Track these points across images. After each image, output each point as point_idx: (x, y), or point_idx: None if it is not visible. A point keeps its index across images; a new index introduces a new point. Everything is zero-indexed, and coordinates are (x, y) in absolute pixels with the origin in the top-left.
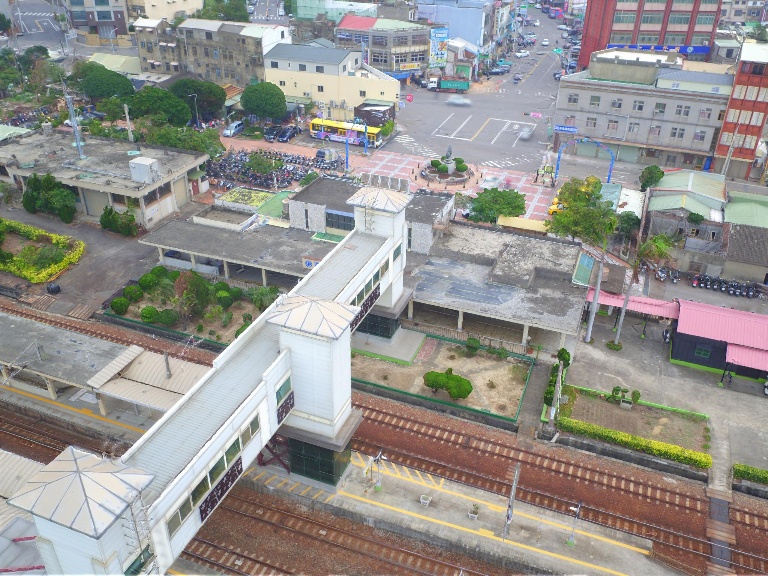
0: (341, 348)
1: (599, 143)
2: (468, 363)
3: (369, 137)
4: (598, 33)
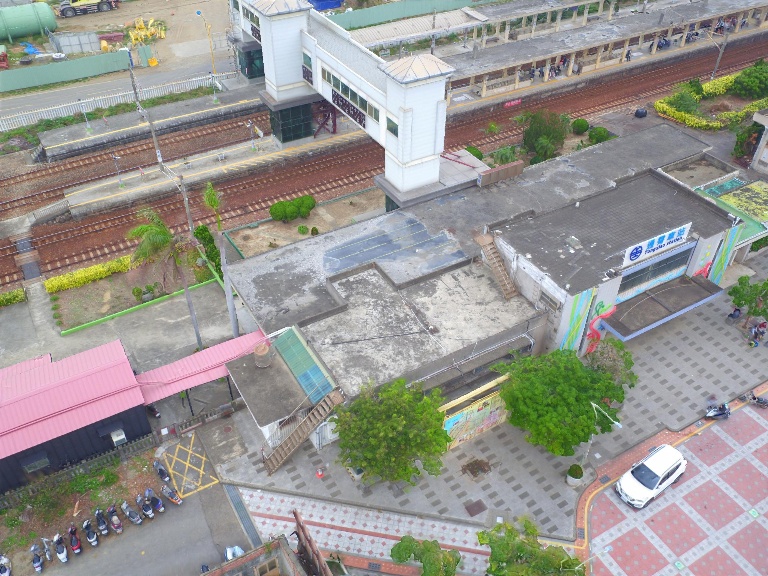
0: None
1: None
2: None
3: None
4: None
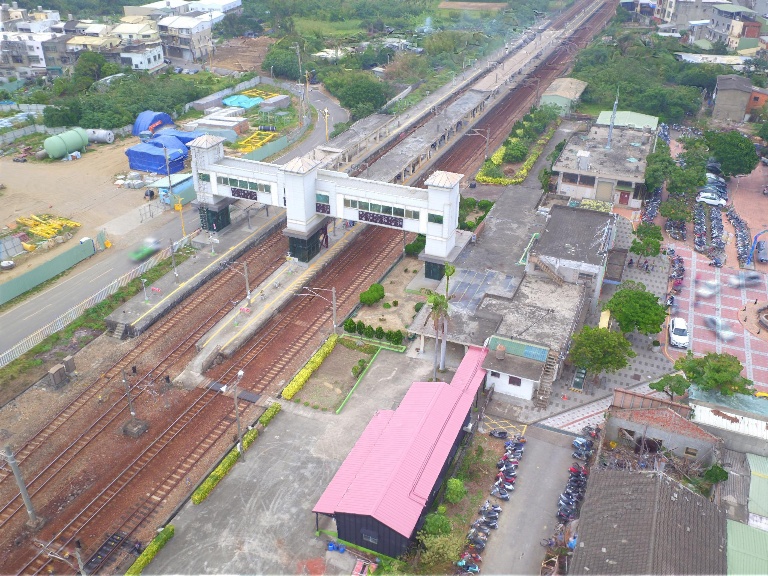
0: (295, 186)
1: None
2: (410, 314)
3: None
4: None
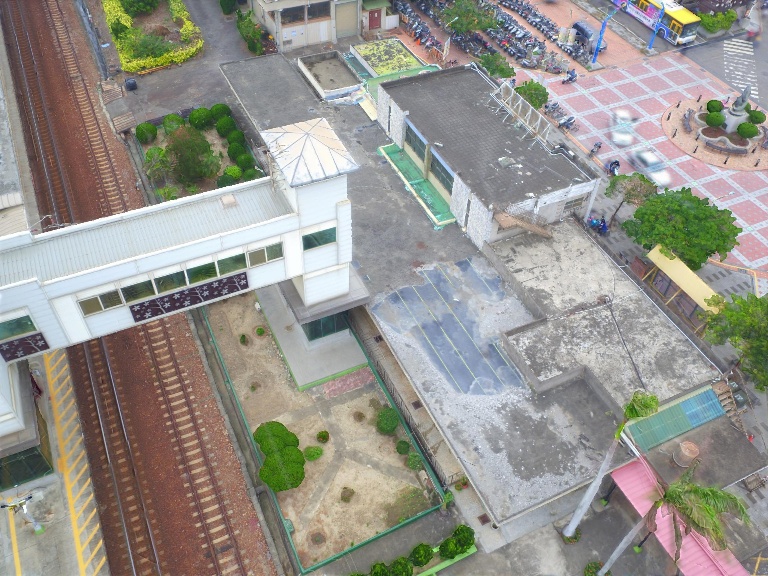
0: None
1: None
2: (367, 439)
3: (674, 26)
4: None
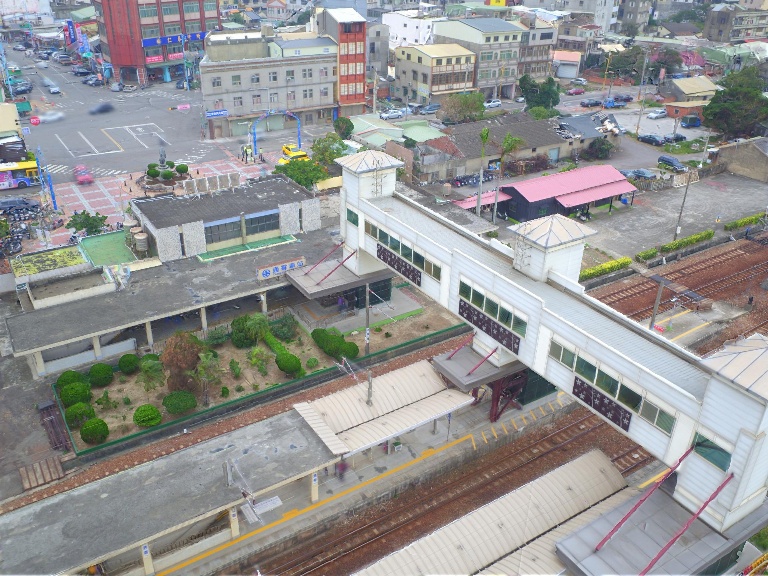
0: None
1: (285, 111)
2: None
3: (30, 173)
4: (128, 30)
